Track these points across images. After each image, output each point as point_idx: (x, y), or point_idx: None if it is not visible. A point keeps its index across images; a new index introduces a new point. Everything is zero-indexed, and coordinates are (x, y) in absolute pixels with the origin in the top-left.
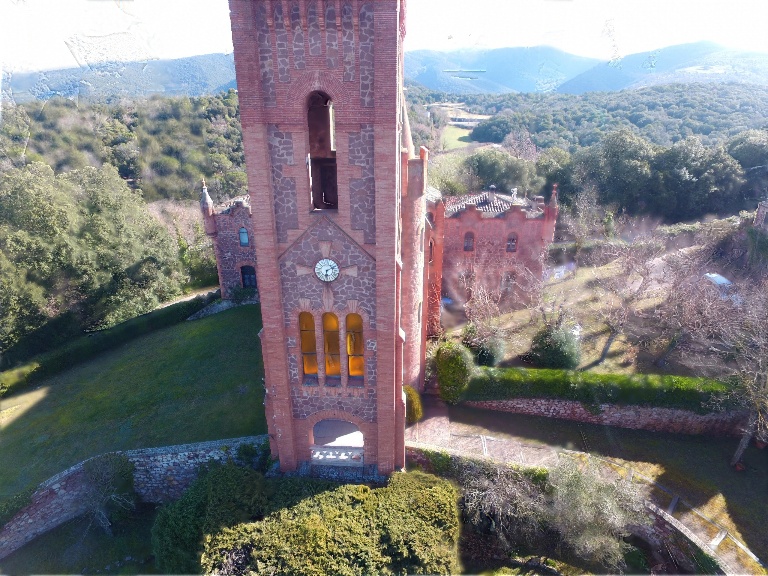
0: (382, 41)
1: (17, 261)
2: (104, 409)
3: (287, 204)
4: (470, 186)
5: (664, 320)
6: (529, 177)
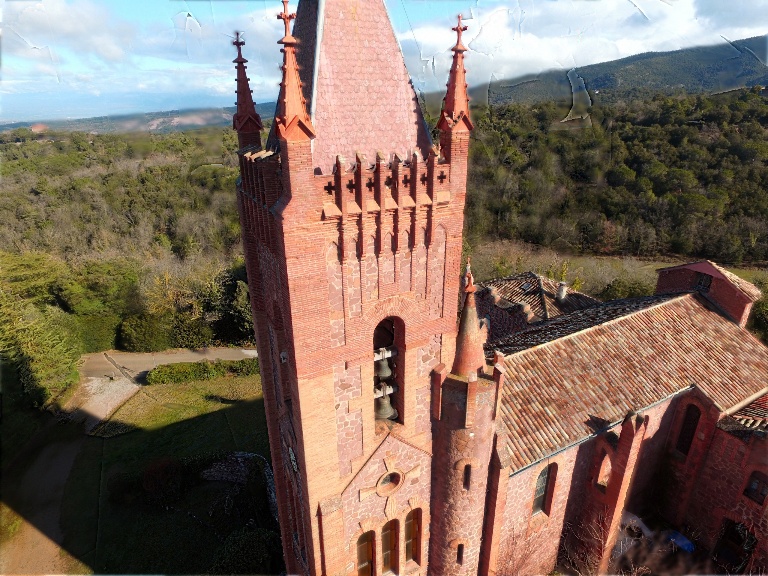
0: (284, 286)
1: None
2: None
3: None
4: None
5: None
6: None
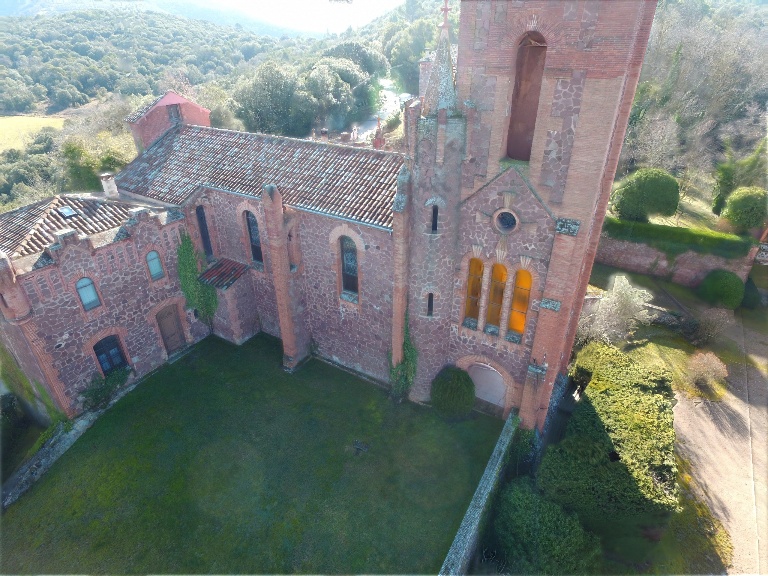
0: None
1: None
2: None
3: None
4: None
5: None
6: None
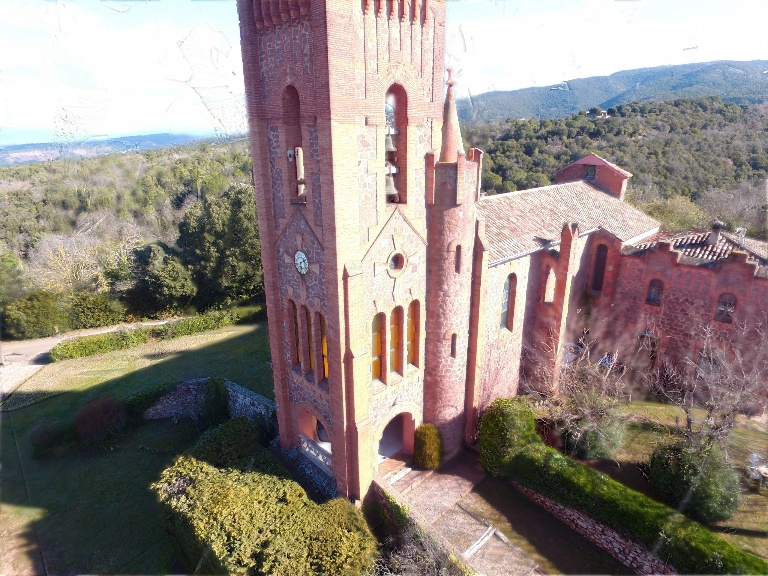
0: (318, 27)
1: None
2: (261, 351)
3: (279, 194)
4: (758, 227)
5: None
6: None
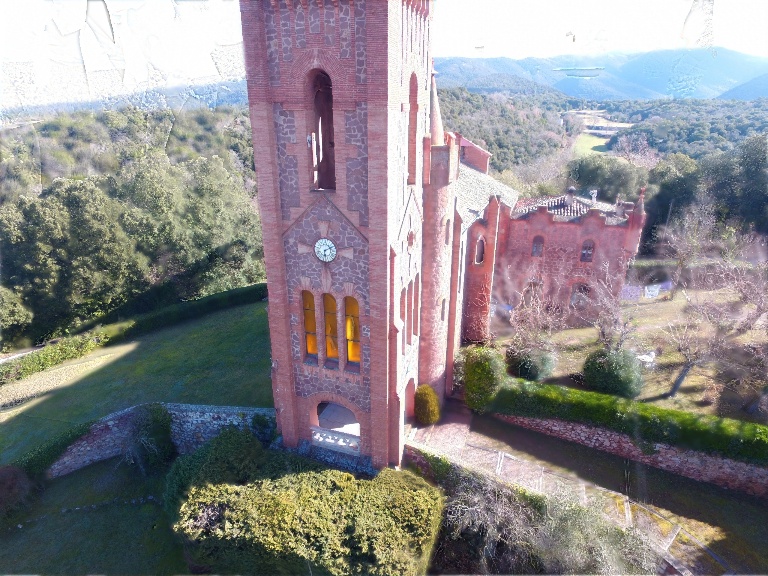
0: (374, 14)
1: (131, 233)
2: (170, 366)
3: (290, 182)
4: (565, 191)
5: (758, 356)
6: (638, 184)
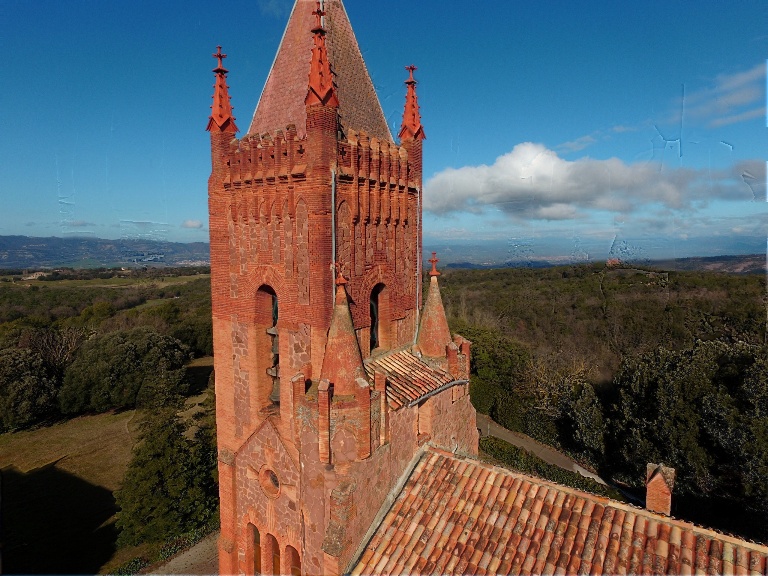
0: None
1: None
2: None
3: None
4: None
5: None
6: None
